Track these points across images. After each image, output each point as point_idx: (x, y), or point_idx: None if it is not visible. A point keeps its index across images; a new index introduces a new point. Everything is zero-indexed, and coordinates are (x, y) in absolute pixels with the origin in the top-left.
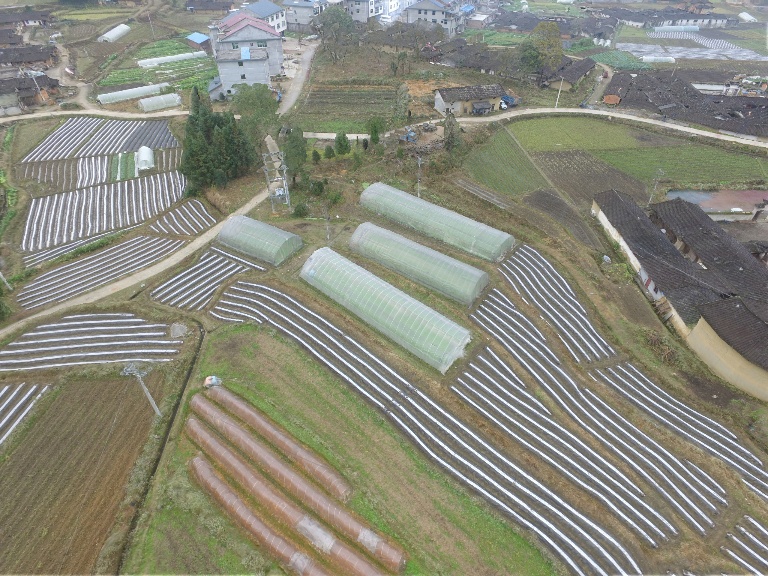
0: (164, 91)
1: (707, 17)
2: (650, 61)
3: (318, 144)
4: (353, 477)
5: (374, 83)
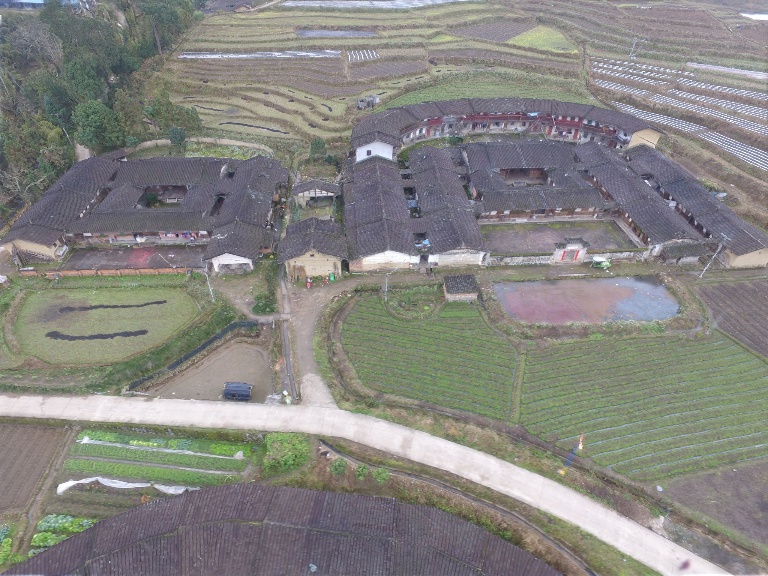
0: None
1: None
2: None
3: None
4: None
5: None
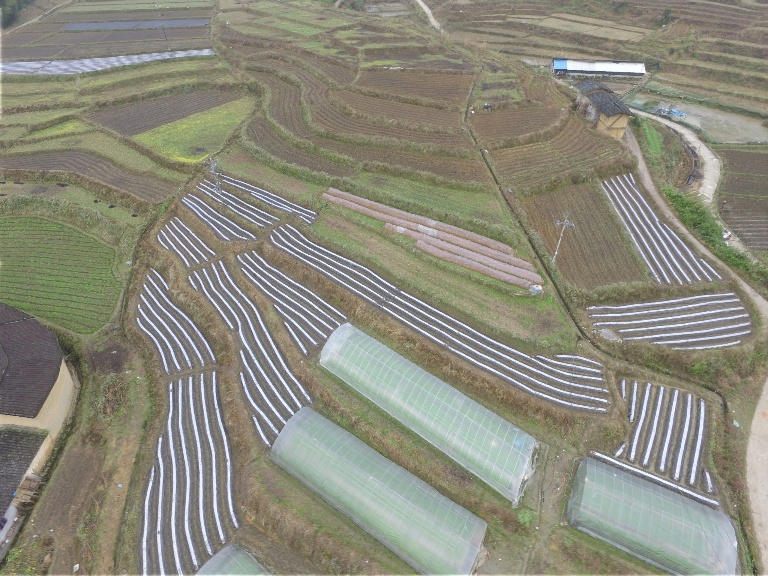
0: None
1: None
2: None
3: None
4: (415, 249)
5: None
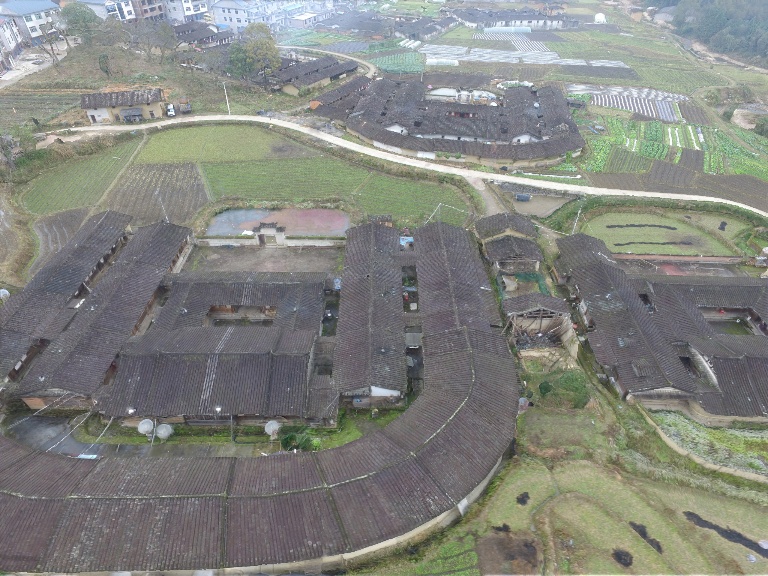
0: None
1: (541, 18)
2: (433, 64)
3: None
4: None
5: (79, 86)
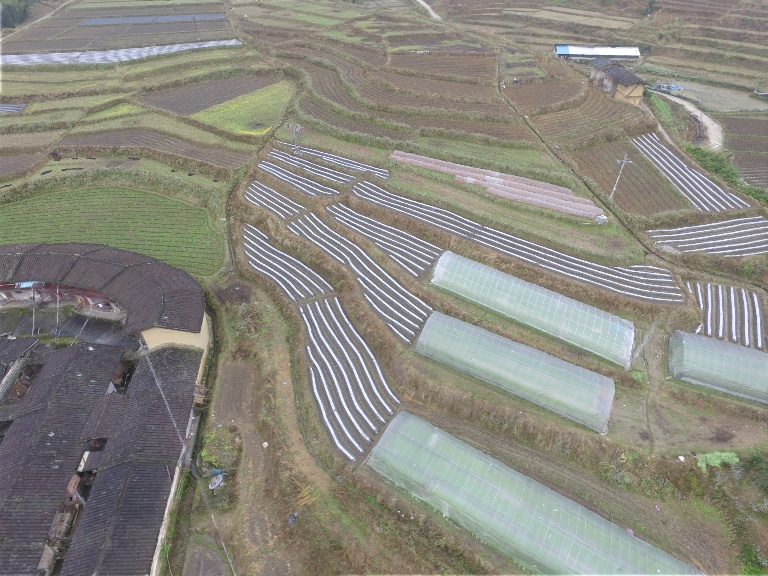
0: None
1: None
2: None
3: None
4: (488, 194)
5: None
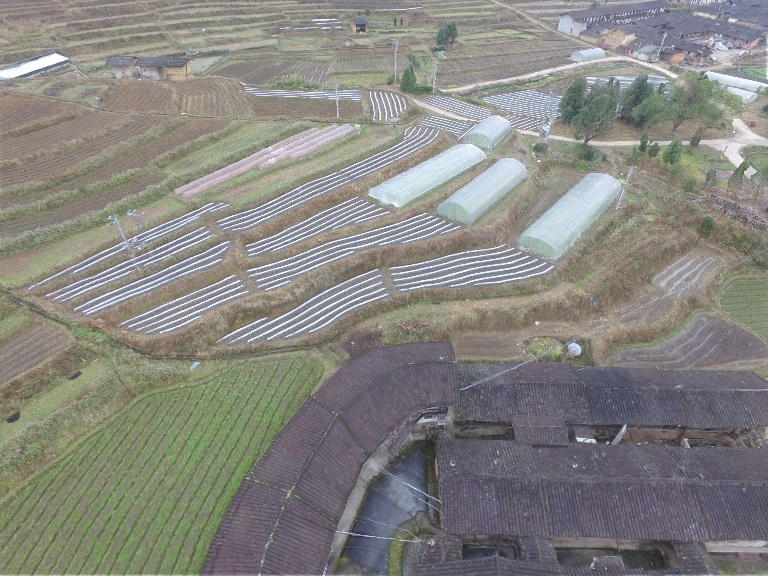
0: (762, 91)
1: None
2: None
3: (726, 171)
4: (299, 158)
5: None
